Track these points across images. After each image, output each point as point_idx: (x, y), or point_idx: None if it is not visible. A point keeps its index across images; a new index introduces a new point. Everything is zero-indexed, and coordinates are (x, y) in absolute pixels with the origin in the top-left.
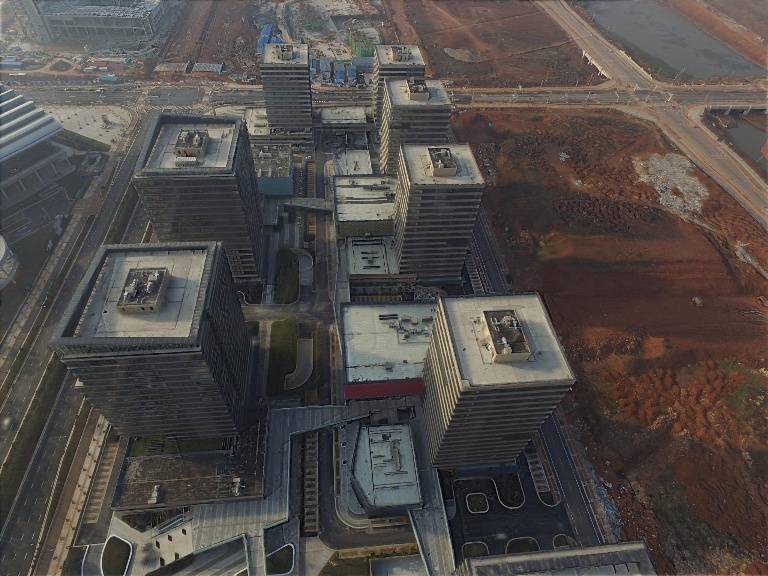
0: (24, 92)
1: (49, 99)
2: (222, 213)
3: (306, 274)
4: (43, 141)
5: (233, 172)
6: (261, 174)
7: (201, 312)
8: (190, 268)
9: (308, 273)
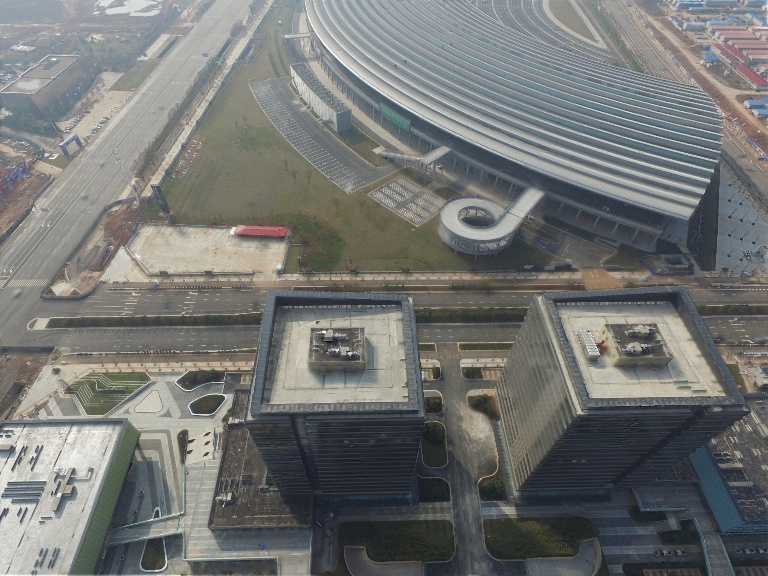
0: (762, 174)
1: (765, 195)
2: (545, 414)
3: (550, 571)
4: (655, 212)
5: (587, 411)
6: (730, 468)
7: (295, 411)
8: (377, 387)
9: (553, 575)
